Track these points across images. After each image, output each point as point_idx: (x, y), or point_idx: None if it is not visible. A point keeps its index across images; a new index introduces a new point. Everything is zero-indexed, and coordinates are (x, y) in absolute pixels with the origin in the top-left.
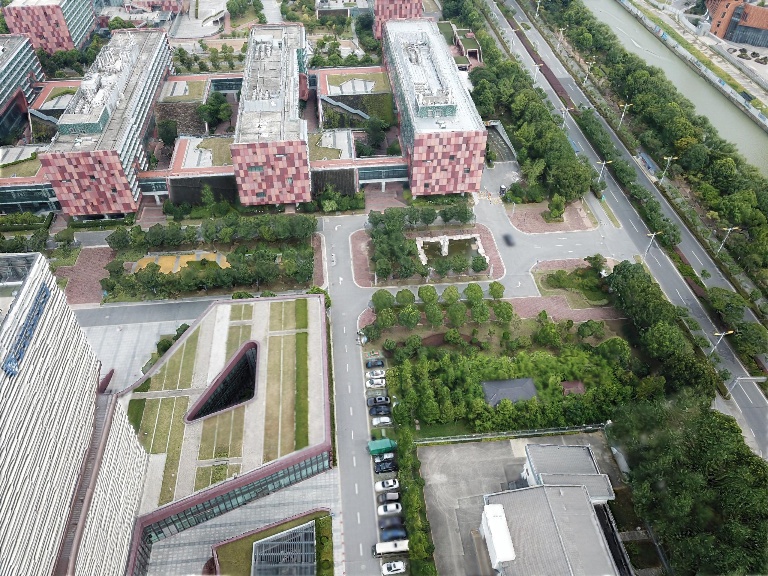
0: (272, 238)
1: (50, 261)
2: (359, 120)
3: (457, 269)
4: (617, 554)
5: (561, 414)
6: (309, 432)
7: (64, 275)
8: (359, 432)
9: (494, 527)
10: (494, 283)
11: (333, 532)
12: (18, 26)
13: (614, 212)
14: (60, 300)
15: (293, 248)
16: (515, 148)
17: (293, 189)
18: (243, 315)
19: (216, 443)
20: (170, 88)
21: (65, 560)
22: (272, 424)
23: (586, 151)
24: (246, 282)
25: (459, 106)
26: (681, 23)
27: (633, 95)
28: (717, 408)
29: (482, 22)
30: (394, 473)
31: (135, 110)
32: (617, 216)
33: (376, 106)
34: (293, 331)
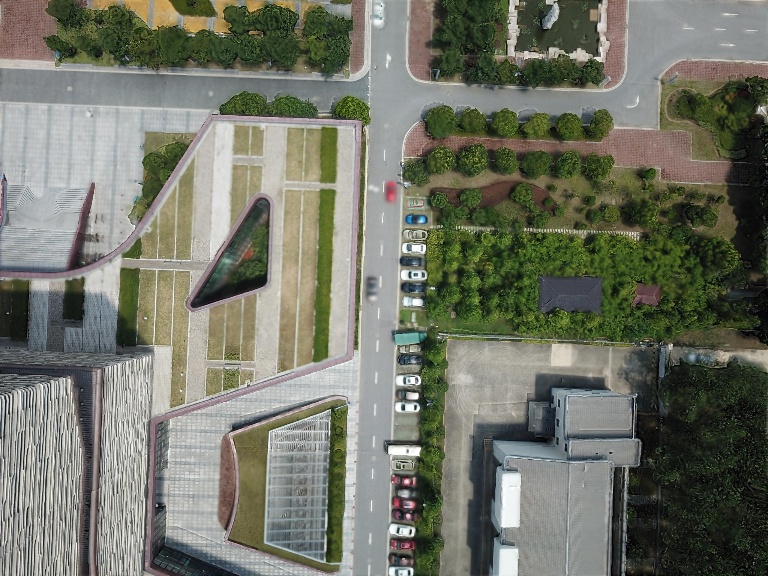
0: None
1: None
2: None
3: (557, 79)
4: (618, 509)
5: (620, 330)
6: (329, 340)
7: None
8: (386, 311)
9: (506, 498)
10: (602, 113)
11: (348, 421)
12: None
13: None
14: None
15: None
16: None
17: None
18: (251, 147)
19: (226, 340)
20: None
21: (85, 565)
22: (288, 323)
23: None
24: None
25: None
26: None
27: None
28: None
29: None
30: (418, 367)
31: None
32: None
33: None
34: (317, 185)
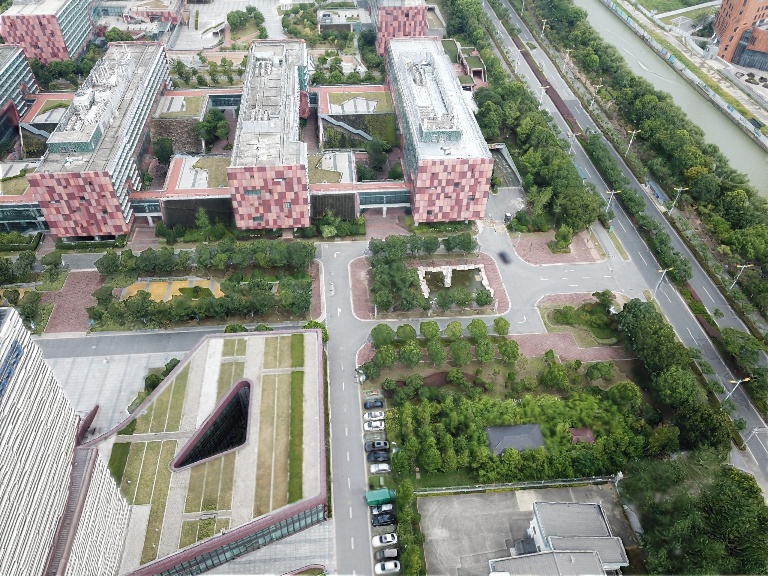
0: (268, 265)
1: (36, 285)
2: (360, 140)
3: (460, 303)
4: None
5: (569, 465)
6: (303, 483)
7: (50, 300)
8: (356, 480)
9: None
10: (499, 319)
11: None
12: (12, 35)
13: (622, 243)
14: (34, 357)
15: (290, 276)
16: (520, 173)
17: (291, 214)
18: (236, 351)
19: (204, 494)
20: (167, 103)
21: None
22: (264, 473)
23: (593, 178)
24: (240, 312)
25: (464, 131)
26: (688, 46)
27: (641, 120)
28: (732, 460)
29: (487, 40)
30: (392, 526)
31: (129, 128)
32: (625, 248)
33: (378, 126)
34: (288, 369)
